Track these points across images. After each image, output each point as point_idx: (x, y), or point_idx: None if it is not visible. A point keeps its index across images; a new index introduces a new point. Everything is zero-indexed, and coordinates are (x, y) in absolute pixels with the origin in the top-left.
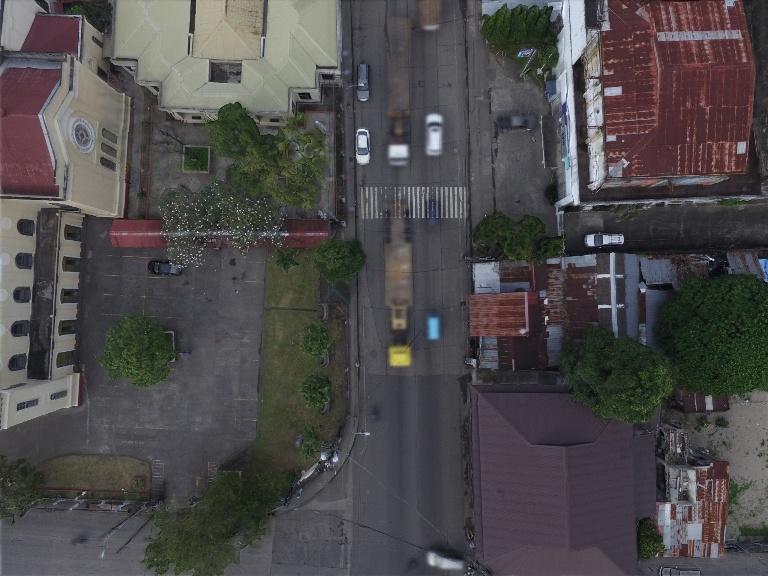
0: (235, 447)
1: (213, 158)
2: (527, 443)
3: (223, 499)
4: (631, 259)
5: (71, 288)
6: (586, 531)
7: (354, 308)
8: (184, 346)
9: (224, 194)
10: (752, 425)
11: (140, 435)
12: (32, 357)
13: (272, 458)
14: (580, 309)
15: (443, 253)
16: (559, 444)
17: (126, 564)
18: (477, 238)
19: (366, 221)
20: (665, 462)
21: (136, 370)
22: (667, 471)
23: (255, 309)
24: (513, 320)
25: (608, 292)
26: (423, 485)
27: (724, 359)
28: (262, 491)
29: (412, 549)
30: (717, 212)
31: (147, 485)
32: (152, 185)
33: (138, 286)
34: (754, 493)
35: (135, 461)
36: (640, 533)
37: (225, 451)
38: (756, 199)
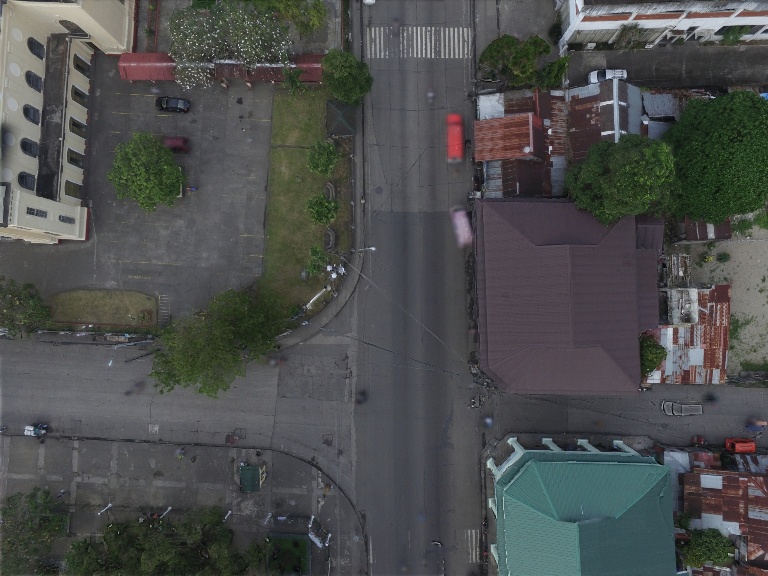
0: (241, 282)
1: None
2: (532, 245)
3: (230, 306)
4: (634, 91)
5: (79, 121)
6: (590, 329)
7: (360, 146)
8: (191, 183)
9: (233, 8)
10: (753, 261)
11: (147, 270)
12: (41, 180)
13: (278, 294)
14: (583, 139)
15: (448, 92)
16: (563, 244)
17: (132, 397)
18: (482, 62)
19: (372, 61)
20: (667, 287)
21: (145, 182)
22: (669, 295)
23: (262, 147)
24: (517, 142)
25: (611, 118)
26: (427, 319)
27: (726, 165)
28: (268, 308)
29: (416, 382)
30: (718, 53)
31: (153, 319)
32: (160, 24)
33: (146, 124)
34: (755, 329)
35: (142, 296)
36: (643, 344)
37: (231, 286)
38: (757, 39)
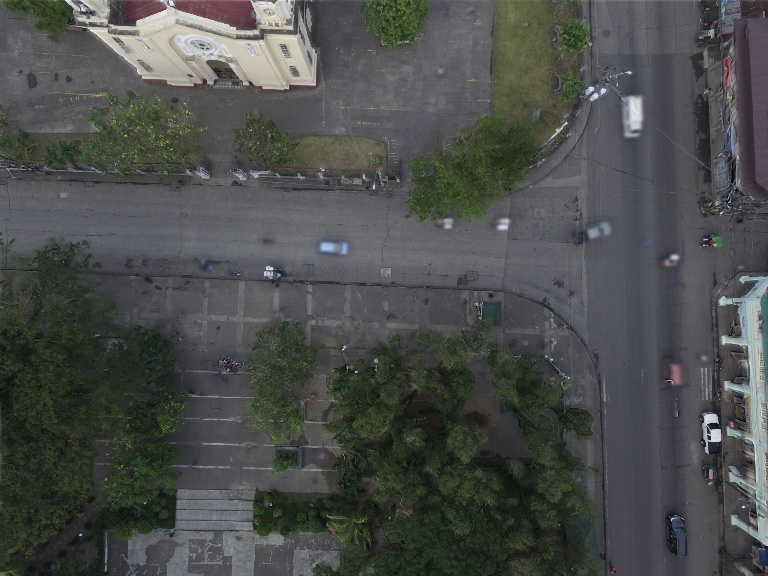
0: (469, 127)
1: None
2: None
3: (496, 125)
4: None
5: None
6: None
7: None
8: None
9: None
10: None
11: (375, 116)
12: None
13: None
14: None
15: None
16: None
17: (364, 241)
18: None
19: None
20: None
21: (405, 6)
22: None
23: None
24: None
25: None
26: (657, 160)
27: None
28: (521, 136)
29: (647, 223)
30: None
31: (383, 164)
32: None
33: None
34: None
35: (371, 141)
36: None
37: (459, 131)
38: None
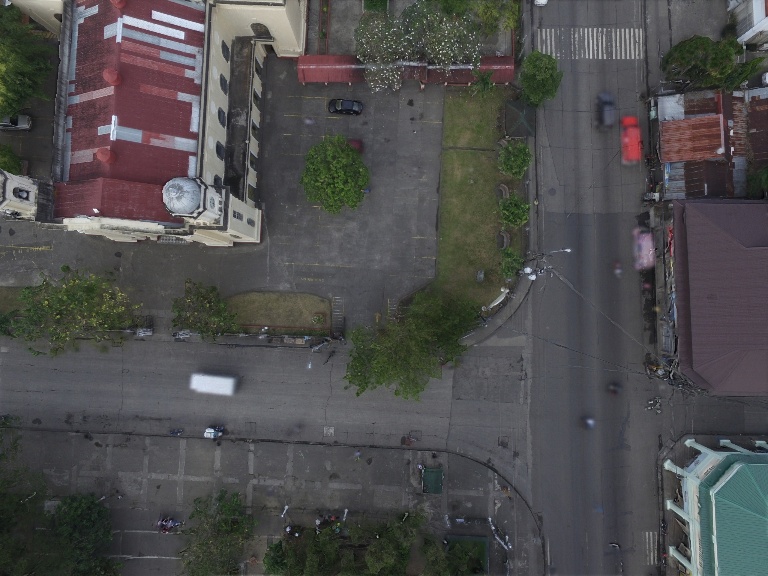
0: (414, 284)
1: (391, 0)
2: (741, 246)
3: (432, 308)
4: None
5: (255, 124)
6: None
7: (532, 147)
8: None
9: (430, 10)
10: None
11: (320, 273)
12: (227, 183)
13: (451, 296)
14: (766, 140)
15: (620, 93)
16: None
17: (307, 399)
18: (671, 63)
19: None
20: None
21: (342, 184)
22: None
23: (433, 149)
24: (708, 143)
25: None
26: (603, 321)
27: None
28: (461, 310)
29: (592, 384)
30: None
31: (327, 322)
32: (331, 27)
33: (317, 126)
34: None
35: (315, 298)
36: None
37: (404, 288)
38: None
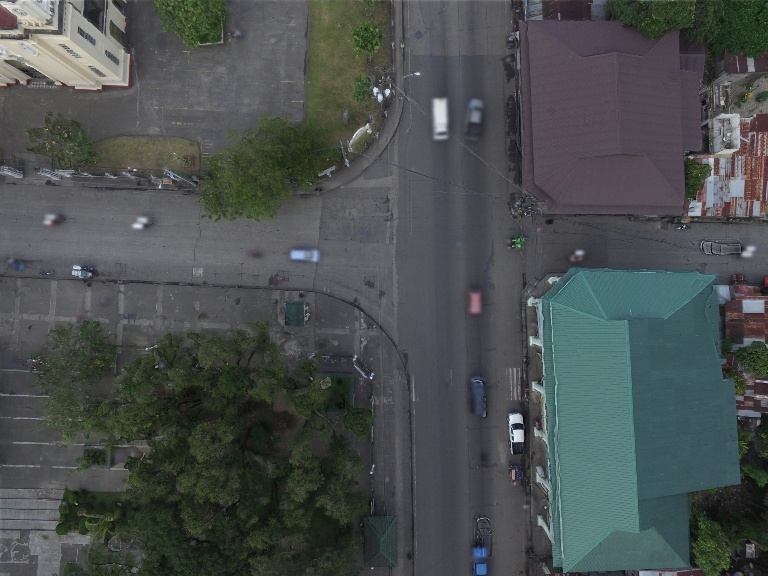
0: None
1: None
2: (578, 56)
3: (278, 126)
4: None
5: None
6: (637, 137)
7: None
8: (232, 30)
9: None
10: None
11: (189, 117)
12: (86, 16)
13: None
14: None
15: None
16: None
17: (176, 241)
18: None
19: None
20: (708, 117)
21: (192, 7)
22: (710, 125)
23: None
24: None
25: None
26: (468, 161)
27: None
28: (314, 136)
29: (457, 224)
30: None
31: (196, 164)
32: None
33: None
34: None
35: (184, 141)
36: (687, 163)
37: None
38: None
